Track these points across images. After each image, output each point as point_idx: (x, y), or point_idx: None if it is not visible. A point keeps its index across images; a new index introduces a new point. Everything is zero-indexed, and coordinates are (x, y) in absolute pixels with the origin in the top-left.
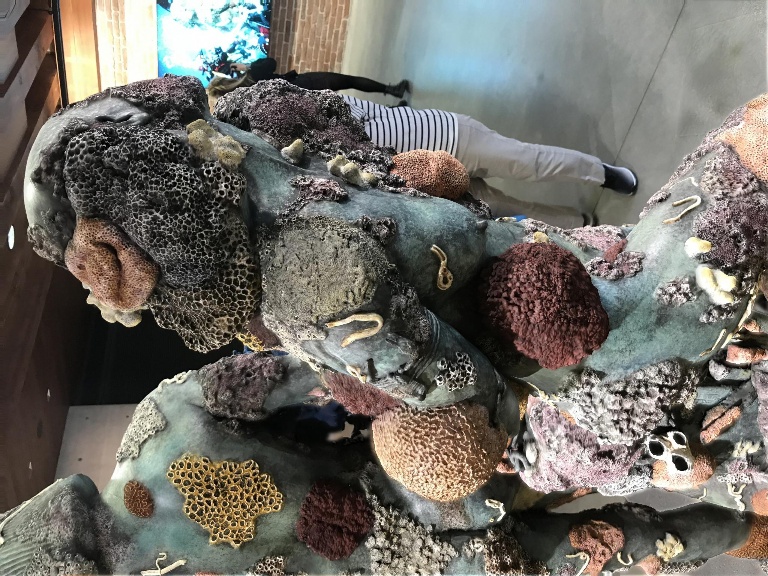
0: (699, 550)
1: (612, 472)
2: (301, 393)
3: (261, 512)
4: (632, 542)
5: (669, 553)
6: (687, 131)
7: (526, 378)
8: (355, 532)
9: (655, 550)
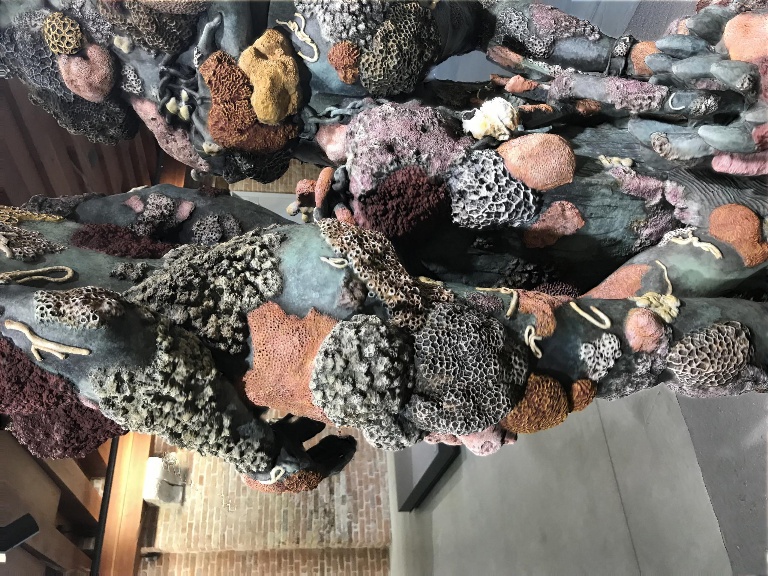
0: (711, 307)
1: (433, 132)
2: (118, 203)
3: (33, 218)
4: (588, 299)
5: (660, 307)
6: (645, 413)
7: (271, 15)
8: (150, 249)
9: (633, 304)
